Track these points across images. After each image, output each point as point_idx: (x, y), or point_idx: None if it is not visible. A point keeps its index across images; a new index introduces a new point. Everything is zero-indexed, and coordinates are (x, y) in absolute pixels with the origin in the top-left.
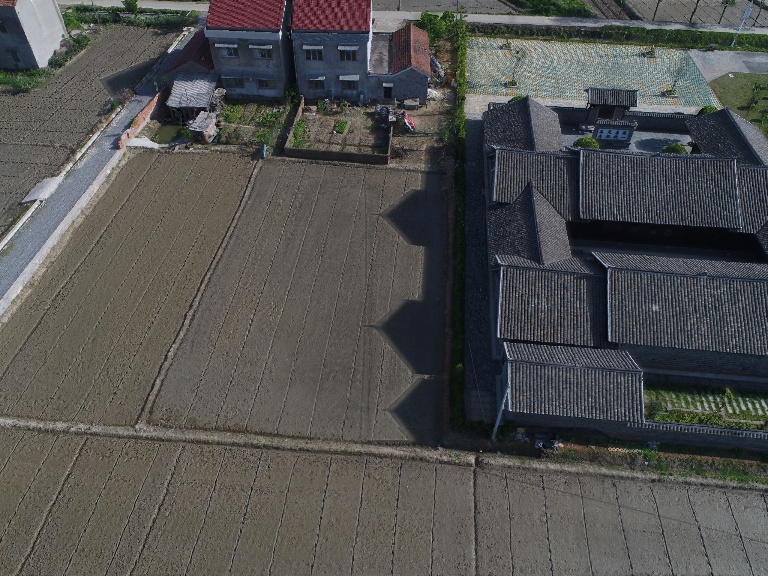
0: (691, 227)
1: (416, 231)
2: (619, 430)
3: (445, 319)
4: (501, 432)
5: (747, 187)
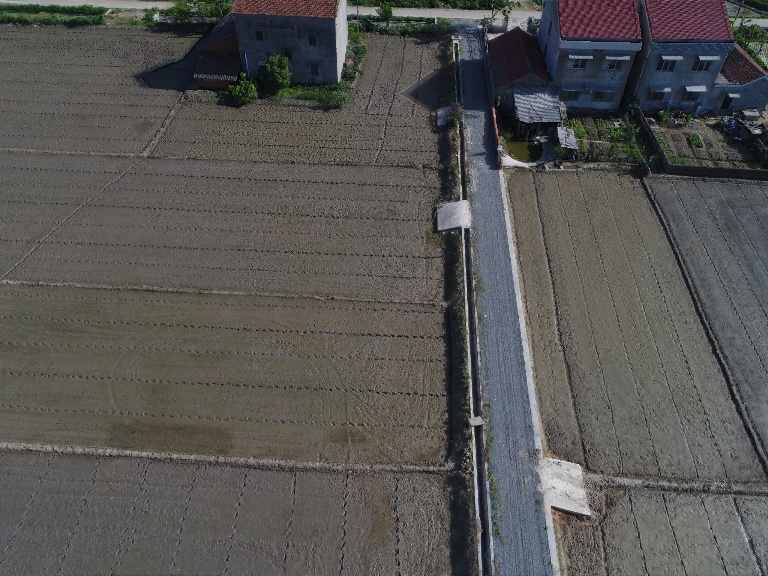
0: None
1: None
2: None
3: None
4: None
5: None
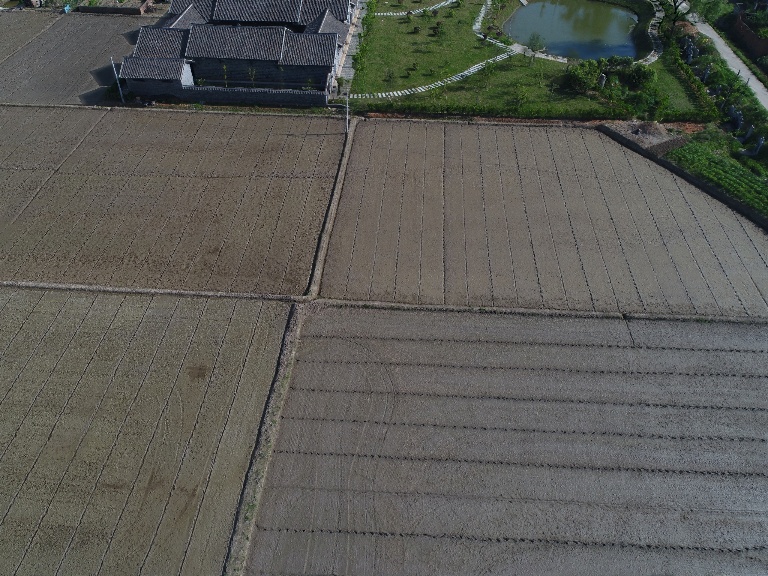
0: (273, 22)
1: None
2: (183, 94)
3: None
4: (126, 97)
5: (309, 3)
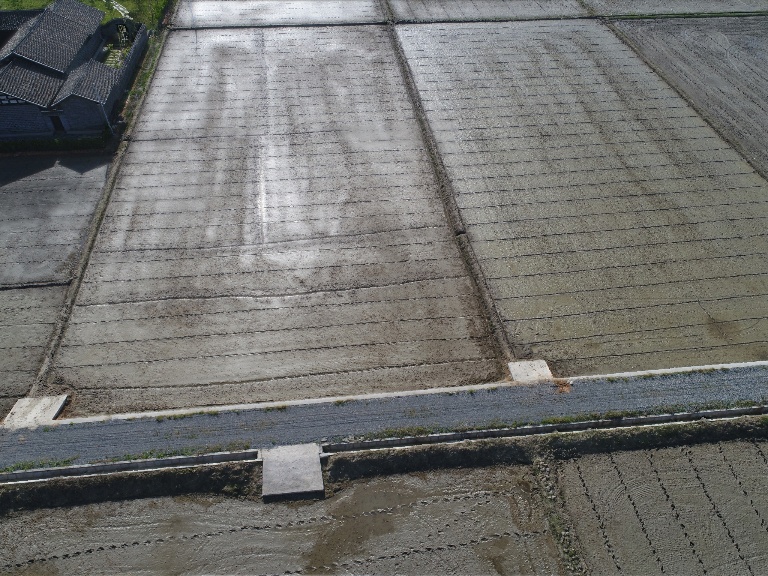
0: None
1: None
2: None
3: (5, 157)
4: None
5: None
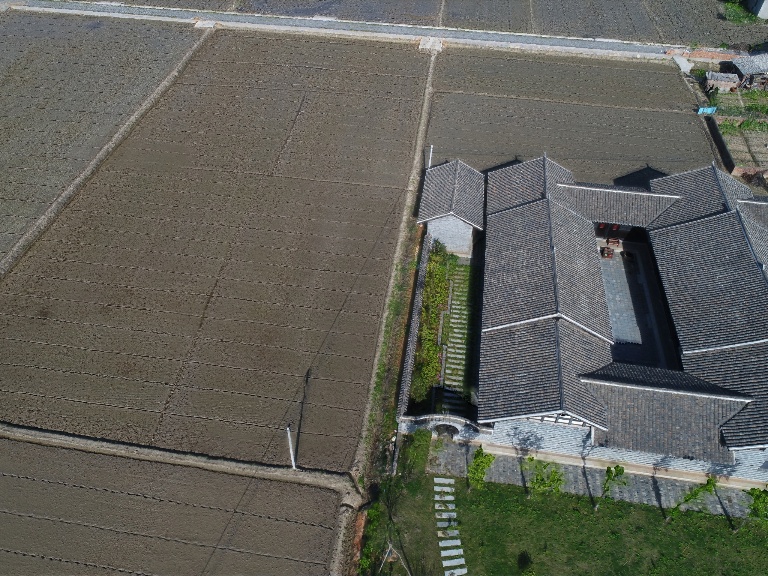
0: None
1: (633, 184)
2: None
3: None
4: None
5: (759, 360)
